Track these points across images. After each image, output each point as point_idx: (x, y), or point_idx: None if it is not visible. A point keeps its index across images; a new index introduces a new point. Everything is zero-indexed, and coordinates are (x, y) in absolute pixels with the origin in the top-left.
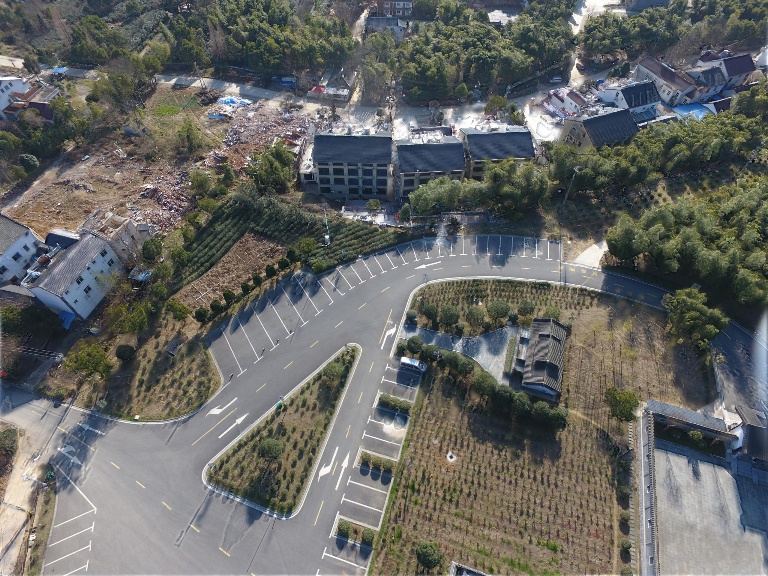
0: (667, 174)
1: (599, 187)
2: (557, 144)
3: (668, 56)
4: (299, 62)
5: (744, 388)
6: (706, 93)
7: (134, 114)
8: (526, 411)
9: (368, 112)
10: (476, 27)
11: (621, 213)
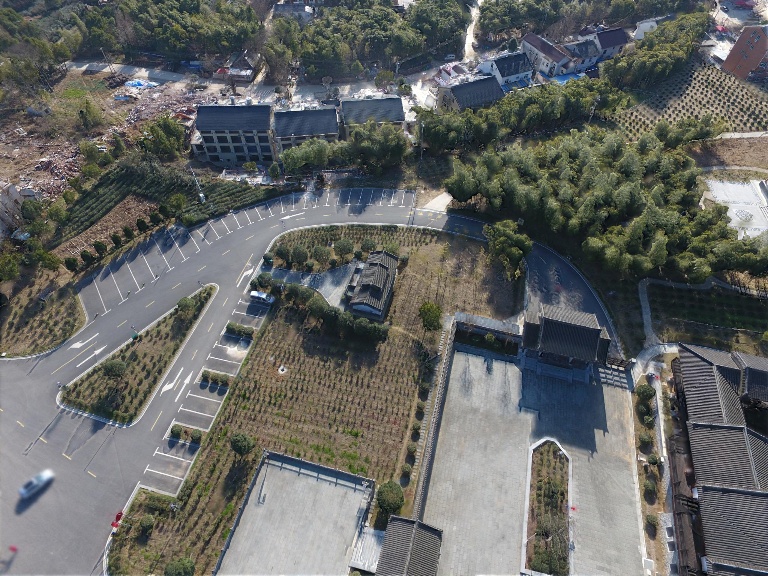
0: (524, 132)
1: (453, 142)
2: (437, 112)
3: (552, 33)
4: (208, 47)
5: (547, 302)
6: (582, 64)
7: (40, 97)
8: (349, 327)
9: (269, 90)
10: (377, 10)
11: (475, 166)
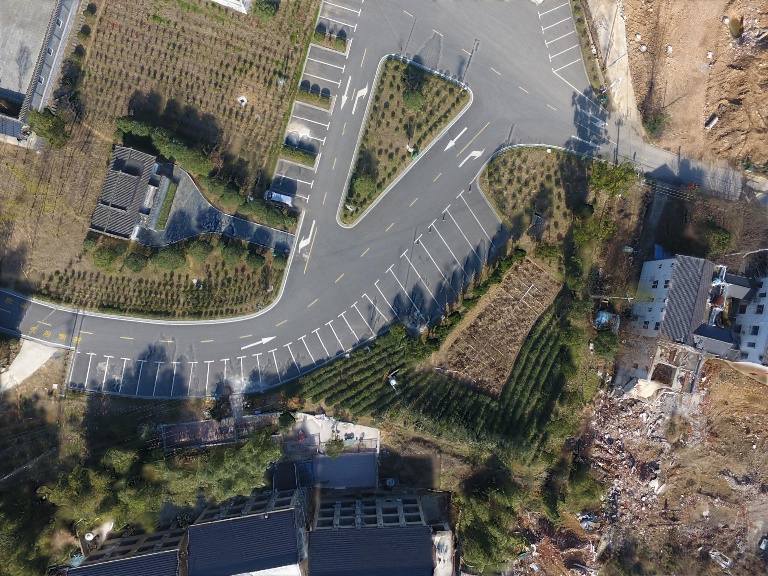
0: None
1: None
2: None
3: None
4: None
5: None
6: None
7: None
8: None
9: None
10: None
11: None
